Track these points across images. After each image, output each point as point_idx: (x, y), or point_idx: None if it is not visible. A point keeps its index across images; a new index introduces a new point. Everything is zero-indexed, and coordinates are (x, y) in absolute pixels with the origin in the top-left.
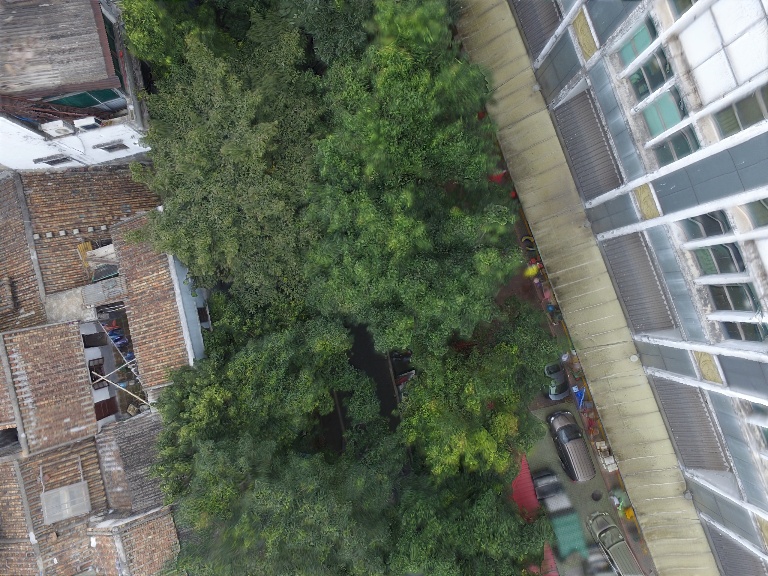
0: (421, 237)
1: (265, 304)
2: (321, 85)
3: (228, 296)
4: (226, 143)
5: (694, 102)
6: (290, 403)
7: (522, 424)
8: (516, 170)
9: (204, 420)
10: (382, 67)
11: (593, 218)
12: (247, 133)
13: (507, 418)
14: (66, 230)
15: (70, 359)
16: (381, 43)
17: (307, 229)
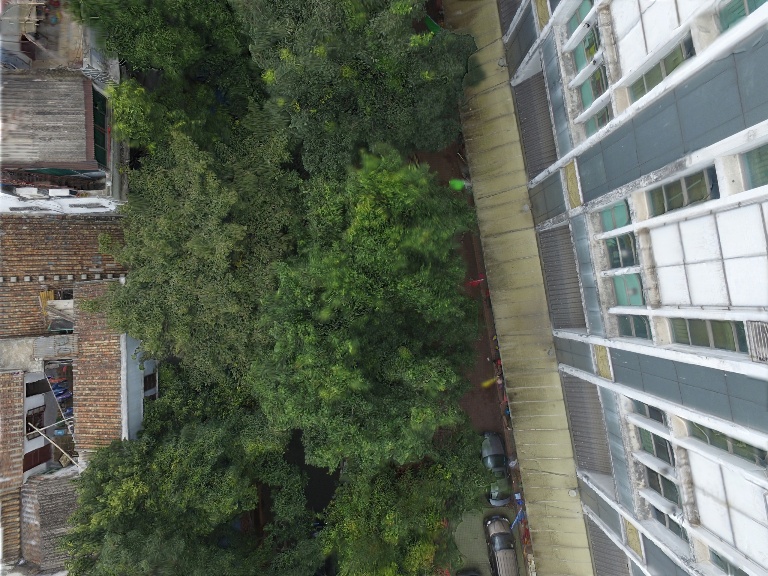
0: (359, 380)
1: (213, 383)
2: (303, 187)
3: (178, 368)
4: (194, 236)
5: (654, 297)
6: (209, 502)
7: (440, 554)
8: (494, 279)
9: (118, 510)
10: (353, 205)
11: (558, 346)
12: (215, 233)
13: (425, 548)
14: (32, 276)
15: (8, 409)
16: (367, 162)
17: (260, 330)
